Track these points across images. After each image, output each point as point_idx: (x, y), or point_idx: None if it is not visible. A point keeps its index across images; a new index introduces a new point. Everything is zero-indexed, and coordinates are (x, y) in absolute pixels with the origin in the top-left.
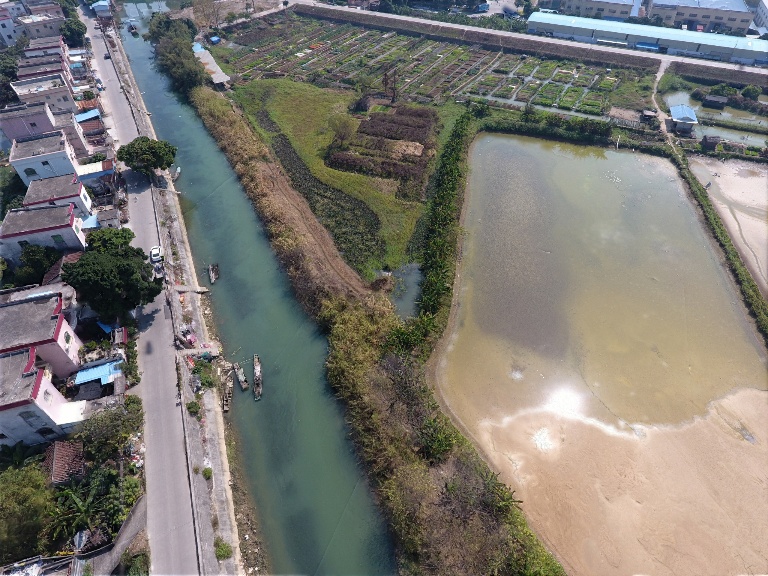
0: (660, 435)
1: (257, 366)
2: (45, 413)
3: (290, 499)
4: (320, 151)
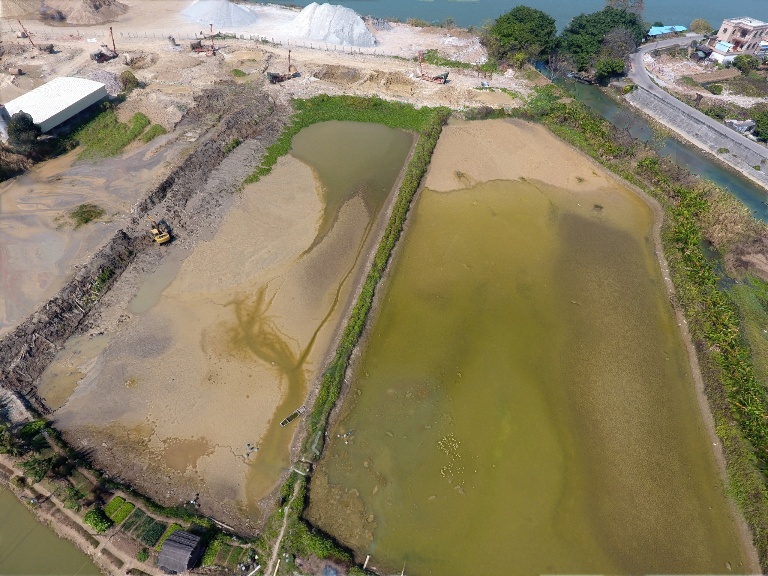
0: (511, 177)
1: None
2: None
3: None
4: None
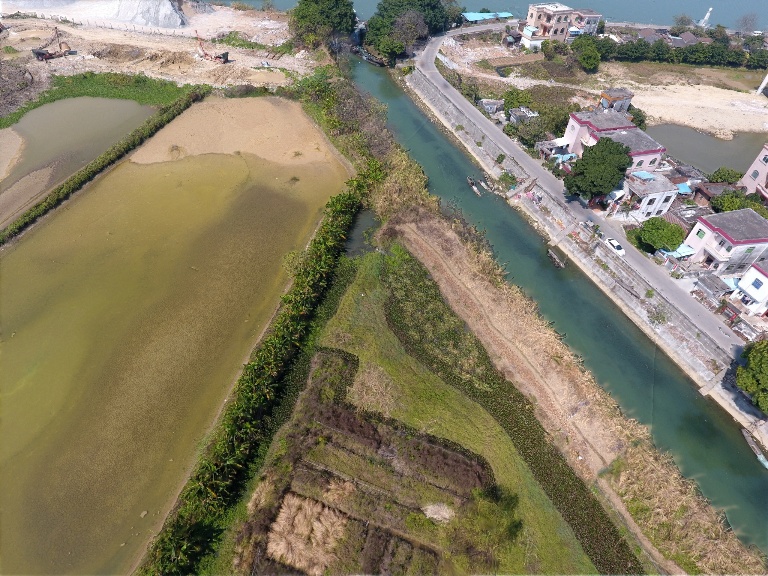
0: (226, 151)
1: (476, 189)
2: (567, 127)
3: (436, 145)
4: (514, 520)
